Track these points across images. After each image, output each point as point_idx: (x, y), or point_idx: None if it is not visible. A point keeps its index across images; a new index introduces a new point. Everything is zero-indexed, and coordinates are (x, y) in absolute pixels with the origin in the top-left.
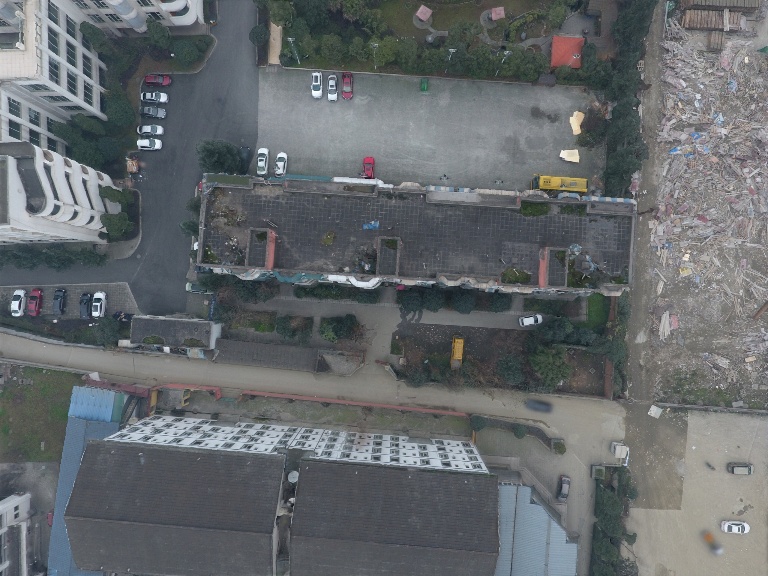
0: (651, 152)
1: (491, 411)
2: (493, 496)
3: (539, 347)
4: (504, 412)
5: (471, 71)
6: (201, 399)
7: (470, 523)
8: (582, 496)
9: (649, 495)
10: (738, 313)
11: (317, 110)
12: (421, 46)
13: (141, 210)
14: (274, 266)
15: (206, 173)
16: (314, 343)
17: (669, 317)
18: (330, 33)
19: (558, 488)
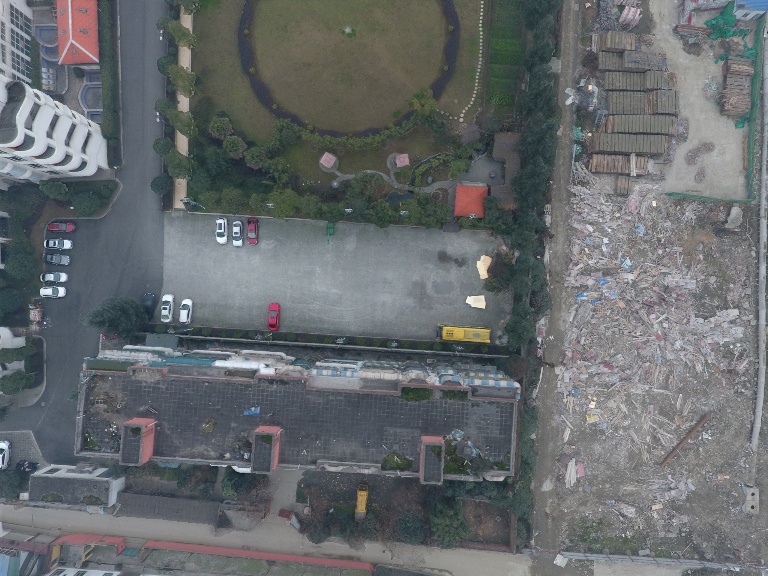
0: (558, 297)
1: (396, 561)
2: None
3: (438, 506)
4: None
5: None
6: (105, 549)
7: None
8: None
9: None
10: (645, 460)
11: (223, 255)
12: (326, 191)
13: (45, 357)
14: (154, 453)
15: (86, 358)
16: (219, 492)
17: (575, 465)
18: None
19: None
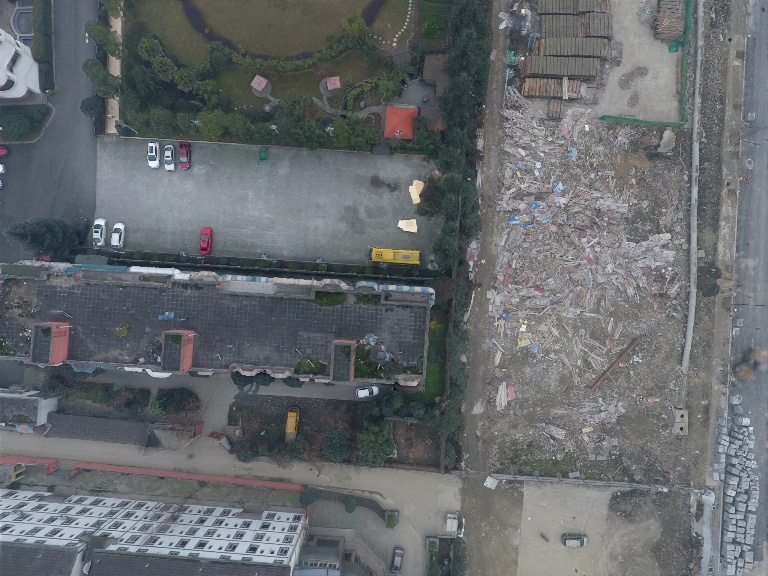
0: (490, 221)
1: (327, 482)
2: None
3: (364, 423)
4: None
5: (303, 143)
6: (38, 471)
7: None
8: (417, 567)
9: (484, 566)
10: (576, 383)
11: (155, 179)
12: (258, 115)
13: None
14: (68, 357)
15: None
16: (151, 415)
17: (506, 388)
18: None
19: (392, 560)
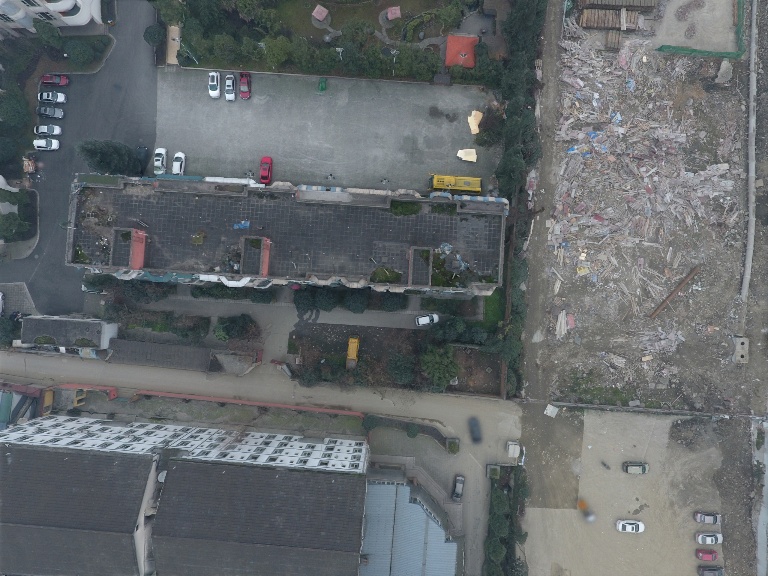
0: (549, 151)
1: (387, 411)
2: (359, 495)
3: (428, 346)
4: (400, 412)
5: (365, 71)
6: (97, 399)
7: (334, 522)
8: (478, 495)
9: (545, 494)
10: (635, 312)
11: (215, 110)
12: (319, 46)
13: (39, 210)
14: (144, 266)
15: (78, 173)
16: (211, 343)
17: (566, 316)
18: (227, 33)
19: (453, 487)
